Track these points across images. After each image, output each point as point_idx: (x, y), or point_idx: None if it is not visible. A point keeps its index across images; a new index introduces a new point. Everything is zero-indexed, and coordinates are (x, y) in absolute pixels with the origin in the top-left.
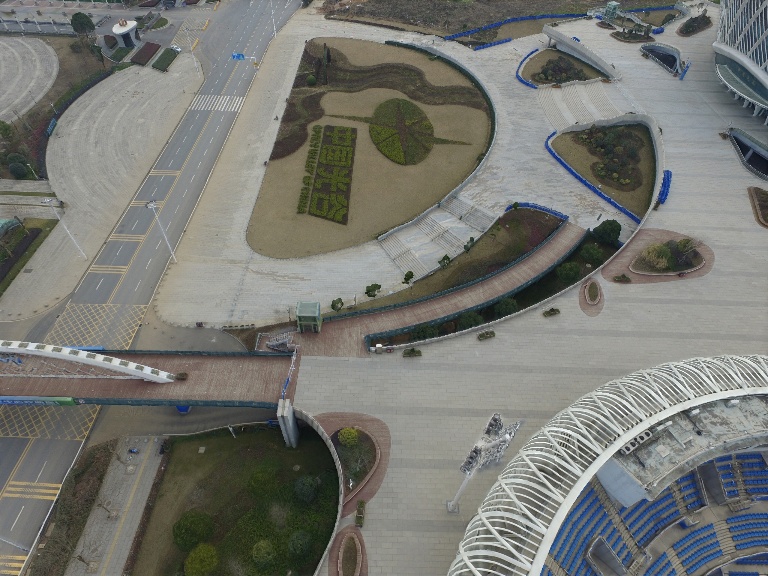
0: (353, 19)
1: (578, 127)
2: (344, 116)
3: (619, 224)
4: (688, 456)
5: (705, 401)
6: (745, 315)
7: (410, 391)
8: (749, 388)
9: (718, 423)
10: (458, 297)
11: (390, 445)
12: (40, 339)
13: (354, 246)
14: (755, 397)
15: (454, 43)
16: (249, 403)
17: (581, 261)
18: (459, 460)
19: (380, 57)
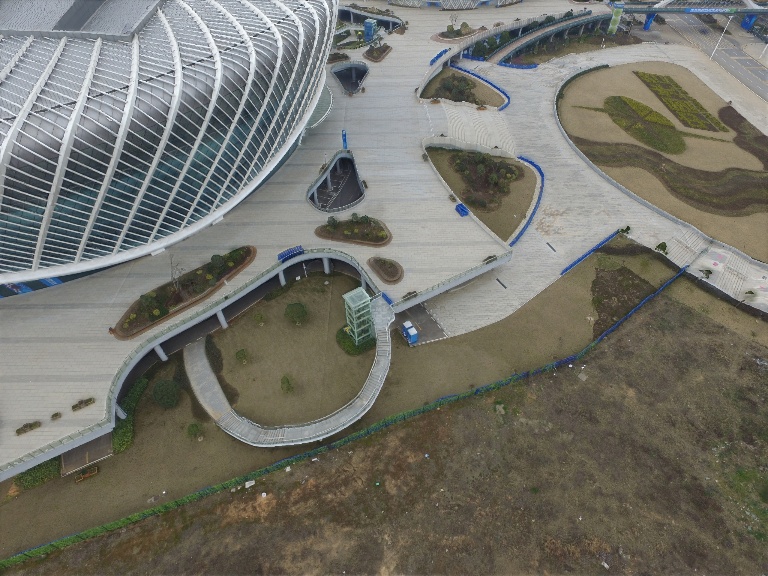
0: None
1: None
2: (711, 139)
3: None
4: None
5: None
6: None
7: (568, 8)
8: None
9: None
10: None
11: (569, 2)
12: (729, 40)
13: None
14: None
15: None
16: None
17: None
18: (547, 1)
19: (762, 232)
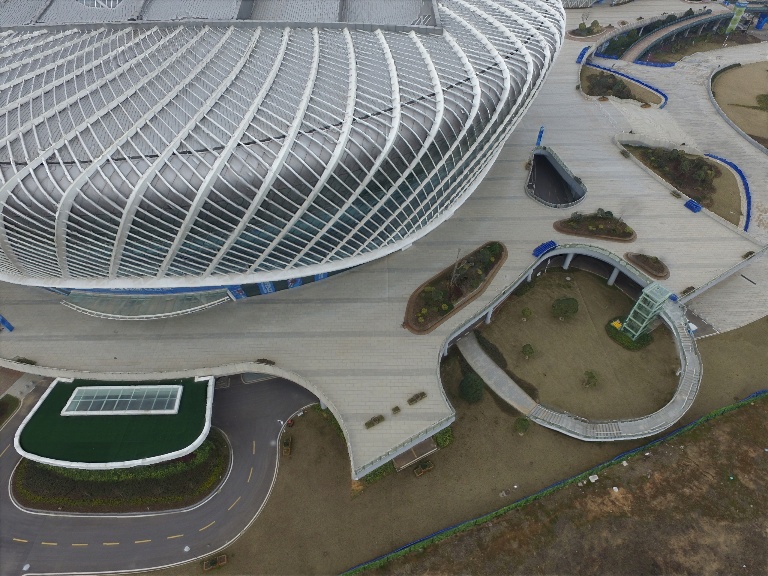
0: None
1: None
2: None
3: (613, 40)
4: None
5: None
6: None
7: (684, 7)
8: None
9: None
10: None
11: (682, 1)
12: None
13: None
14: None
15: None
16: (735, 2)
17: (619, 56)
18: (659, 0)
19: None
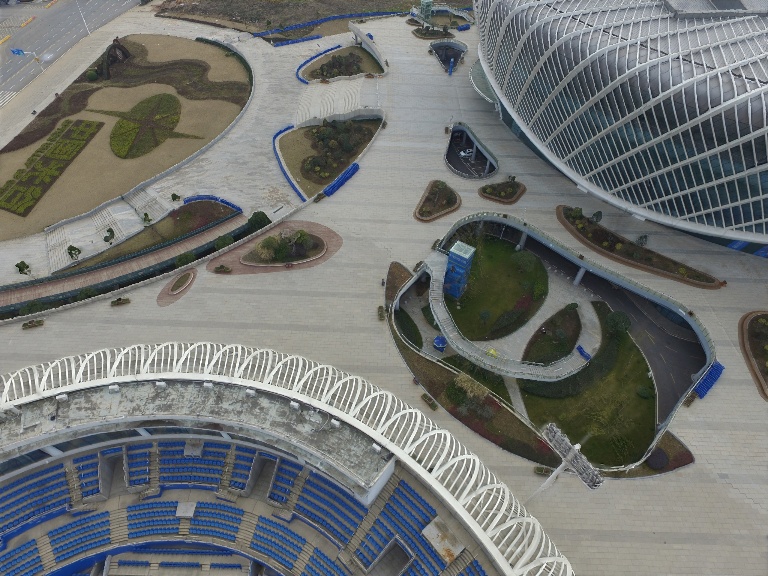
0: (182, 16)
1: (316, 121)
2: (102, 111)
3: (263, 216)
4: (16, 441)
5: (83, 386)
6: (323, 306)
7: None
8: (143, 374)
9: (84, 408)
10: (48, 287)
11: None
12: None
13: (19, 238)
14: (150, 383)
15: (259, 40)
16: None
17: None
18: None
19: (180, 53)
